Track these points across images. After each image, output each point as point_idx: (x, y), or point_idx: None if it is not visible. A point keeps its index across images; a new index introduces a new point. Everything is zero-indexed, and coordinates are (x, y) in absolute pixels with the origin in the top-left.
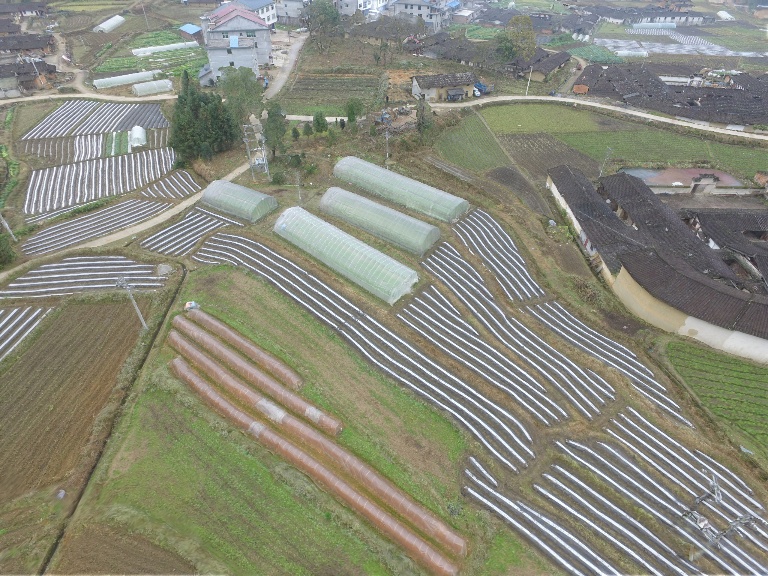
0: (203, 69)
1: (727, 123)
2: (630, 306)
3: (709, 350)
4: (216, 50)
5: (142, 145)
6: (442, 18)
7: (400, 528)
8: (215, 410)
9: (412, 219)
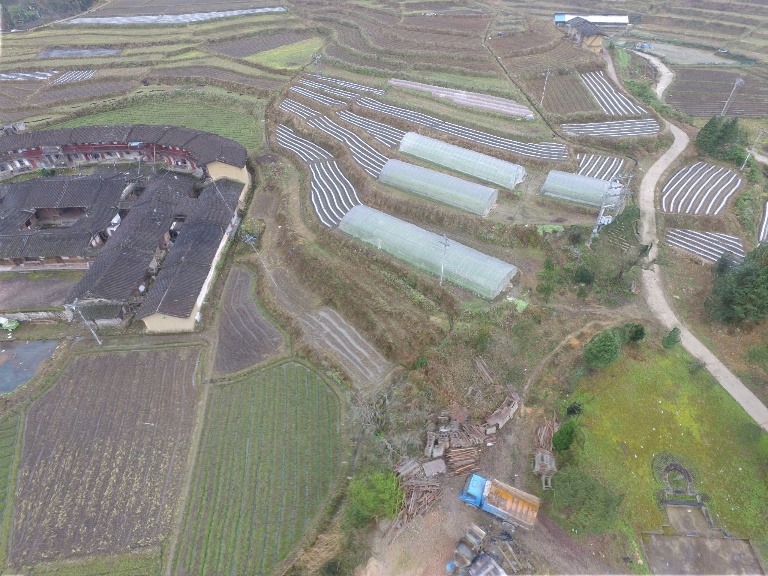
0: None
1: None
2: None
3: None
4: None
5: None
6: None
7: (407, 81)
8: None
9: (404, 169)
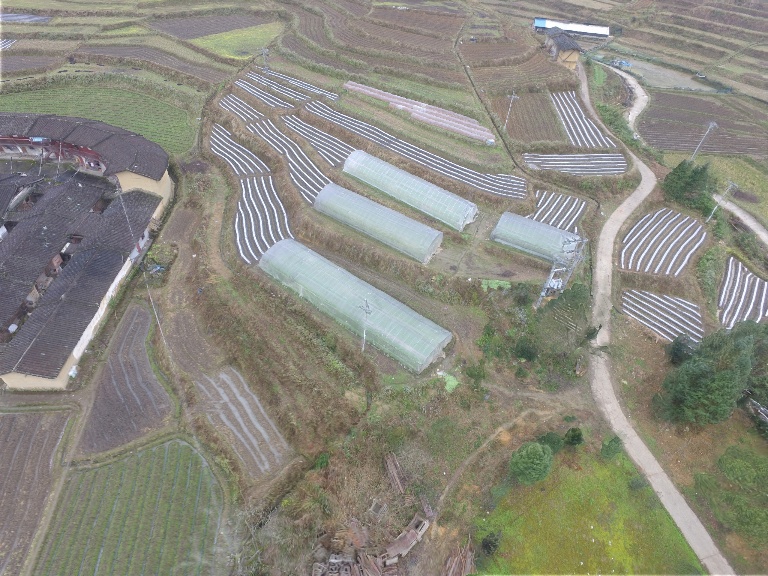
0: None
1: None
2: None
3: None
4: None
5: None
6: None
7: (365, 86)
8: None
9: (342, 198)
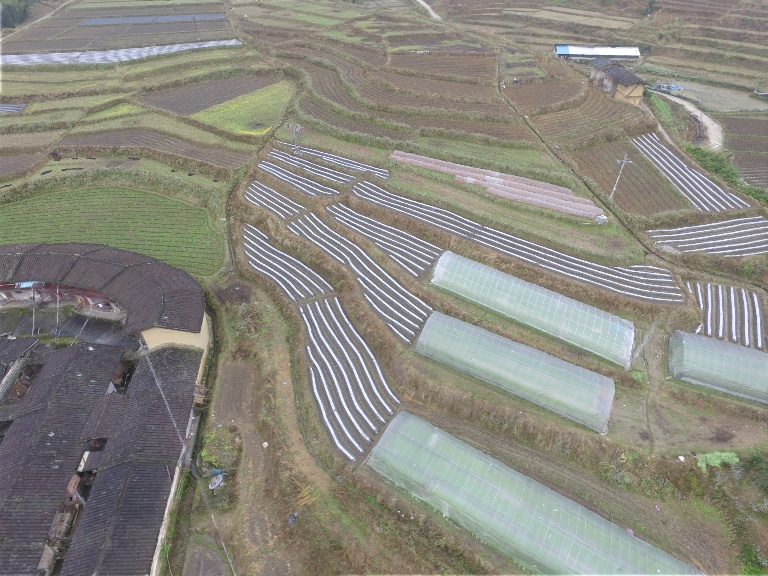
0: None
1: None
2: None
3: None
4: None
5: None
6: None
7: (416, 156)
8: None
9: (457, 338)
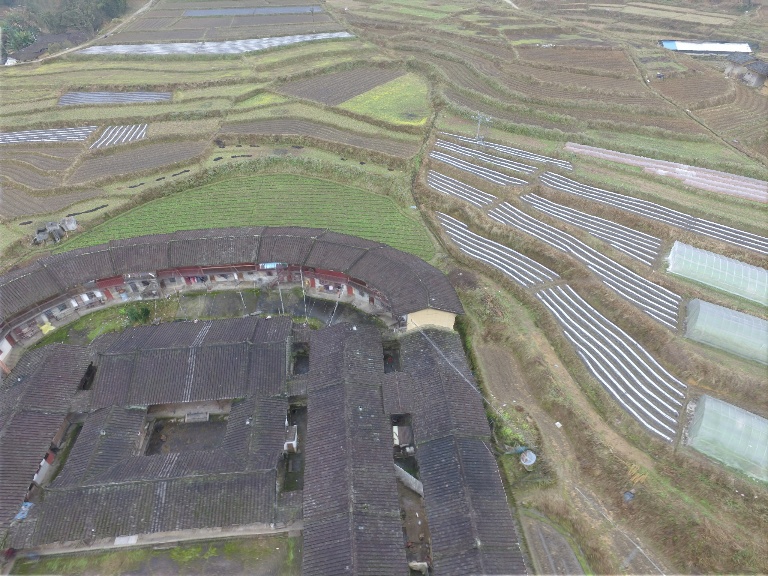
0: None
1: None
2: None
3: None
4: None
5: None
6: None
7: (593, 147)
8: None
9: (740, 325)
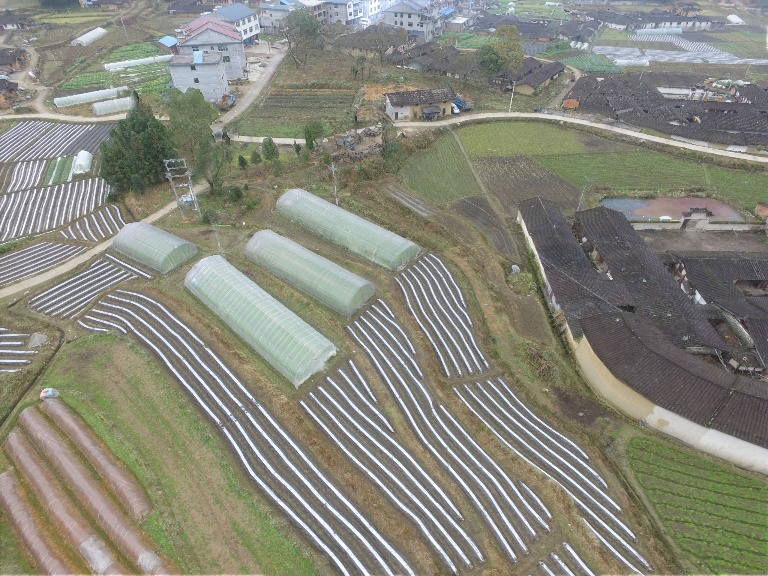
0: (167, 86)
1: (728, 143)
2: (593, 381)
3: (680, 450)
4: (179, 66)
5: (85, 172)
6: (434, 26)
7: None
8: (27, 553)
9: (342, 272)
